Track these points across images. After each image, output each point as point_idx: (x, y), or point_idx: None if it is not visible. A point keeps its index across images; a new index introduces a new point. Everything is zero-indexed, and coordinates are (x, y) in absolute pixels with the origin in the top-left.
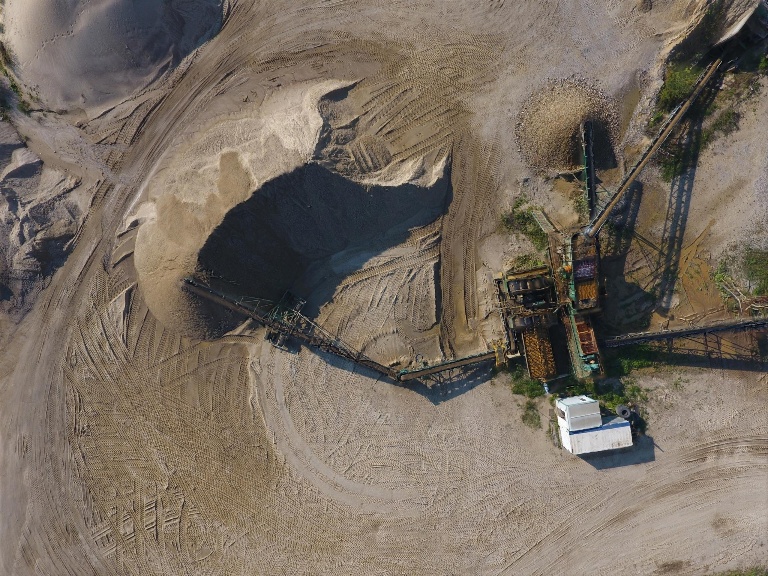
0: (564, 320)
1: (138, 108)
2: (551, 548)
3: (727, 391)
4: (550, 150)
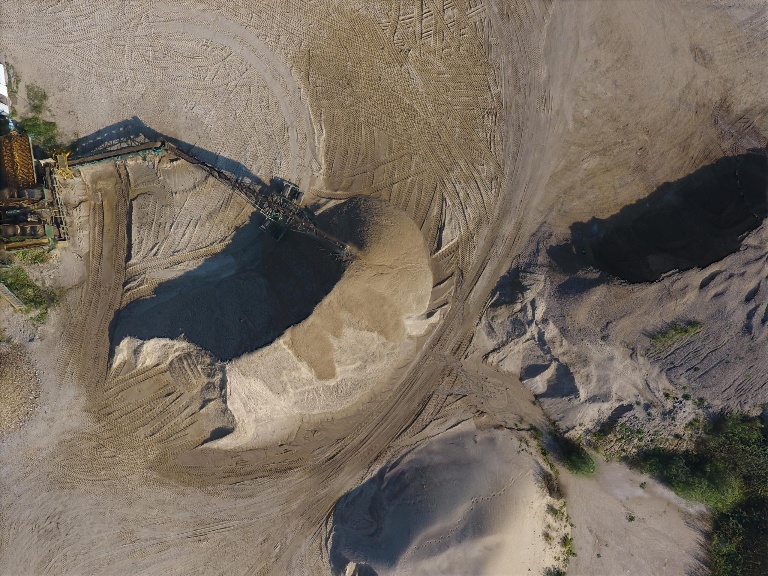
0: None
1: (423, 428)
2: None
3: None
4: (2, 370)
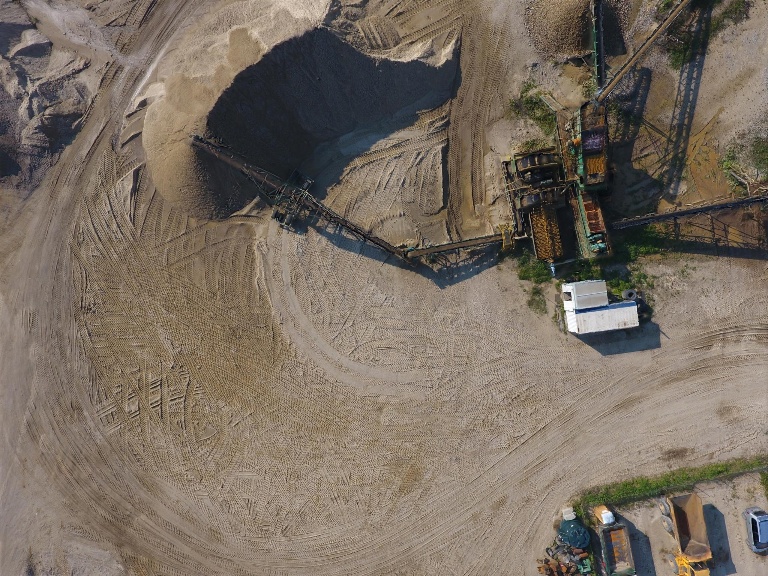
0: (571, 202)
1: None
2: (555, 433)
3: (734, 279)
4: (559, 33)
